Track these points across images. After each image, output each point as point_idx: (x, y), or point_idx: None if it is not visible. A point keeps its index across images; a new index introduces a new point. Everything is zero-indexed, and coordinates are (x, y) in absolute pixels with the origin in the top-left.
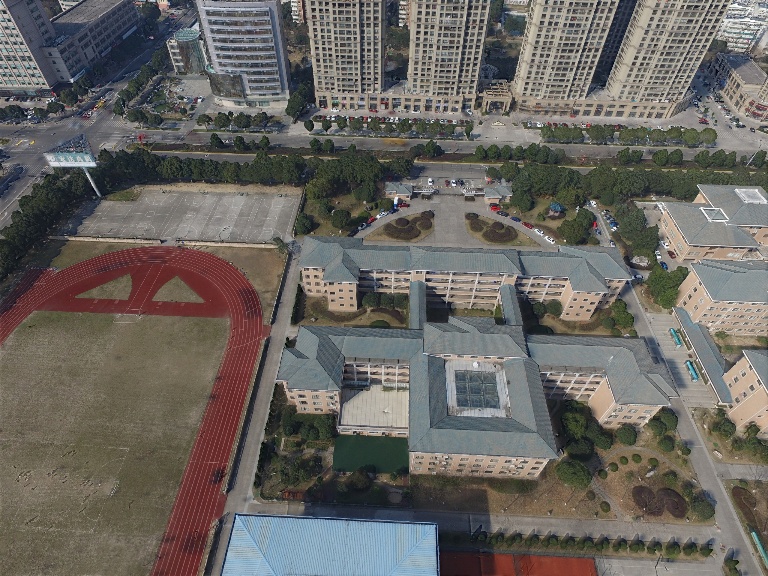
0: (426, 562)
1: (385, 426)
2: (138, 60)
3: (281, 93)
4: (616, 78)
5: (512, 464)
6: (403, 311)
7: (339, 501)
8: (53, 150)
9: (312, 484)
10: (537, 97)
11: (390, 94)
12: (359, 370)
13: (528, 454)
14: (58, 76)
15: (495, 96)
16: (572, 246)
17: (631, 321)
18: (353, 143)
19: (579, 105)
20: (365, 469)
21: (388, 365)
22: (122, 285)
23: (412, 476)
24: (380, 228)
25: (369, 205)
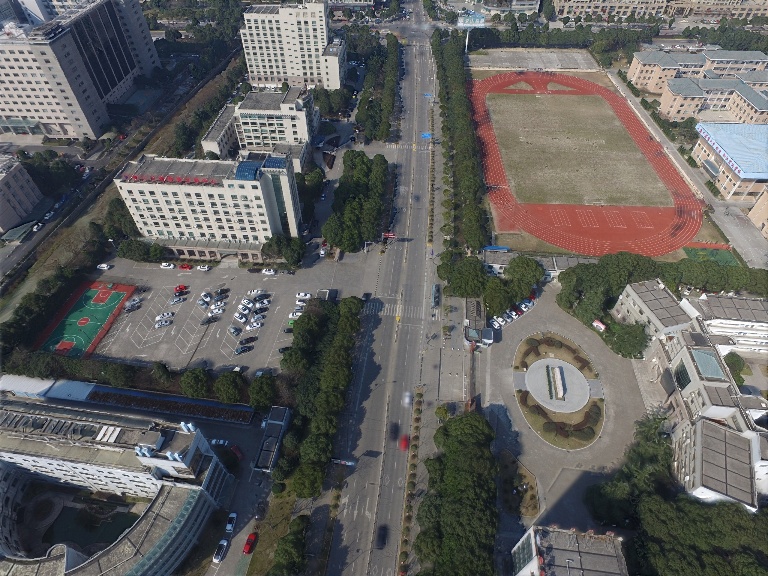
0: None
1: None
2: None
3: (535, 4)
4: None
5: None
6: None
7: None
8: (460, 16)
9: None
10: (708, 4)
11: (609, 3)
12: None
13: None
14: None
15: None
16: None
17: None
18: (596, 31)
19: (736, 9)
20: None
21: (724, 90)
22: (524, 85)
23: None
24: None
25: None
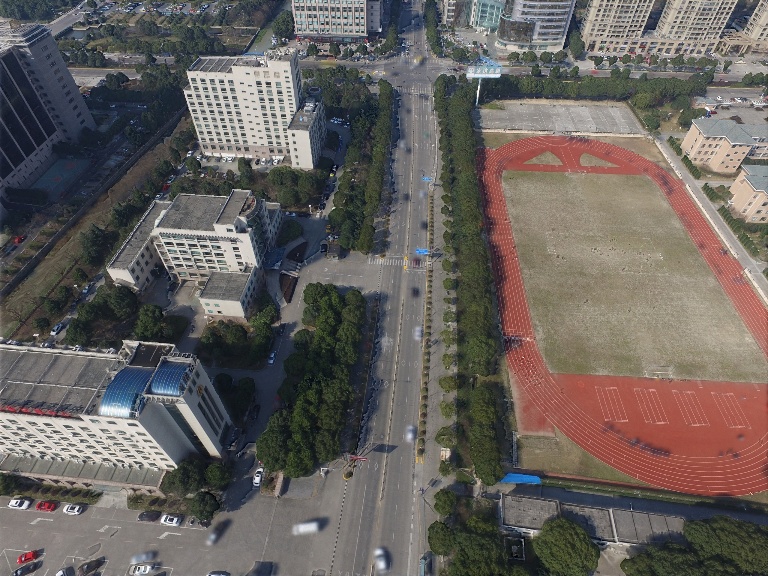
0: None
1: None
2: (402, 18)
3: (560, 38)
4: None
5: None
6: None
7: None
8: (470, 64)
9: None
10: None
11: (650, 39)
12: None
13: None
14: (369, 26)
15: None
16: None
17: None
18: (635, 75)
19: None
20: None
21: None
22: (551, 157)
23: None
24: None
25: None
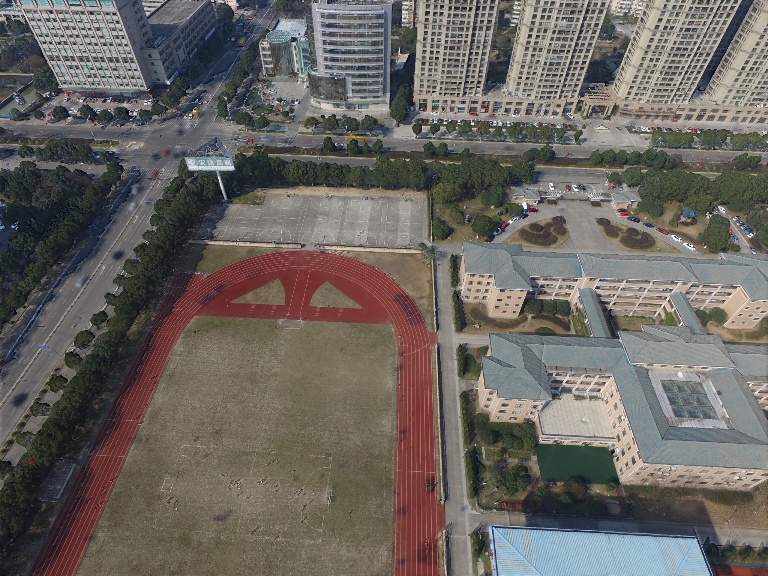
0: None
1: (588, 436)
2: (222, 61)
3: (382, 96)
4: (721, 82)
5: (736, 476)
6: (564, 318)
7: (559, 512)
8: (192, 154)
9: (526, 494)
10: (640, 101)
11: (492, 97)
12: (556, 379)
13: (765, 466)
14: (154, 78)
15: (597, 100)
16: (735, 254)
17: None
18: (462, 147)
19: (682, 109)
20: (575, 479)
21: (590, 374)
22: (275, 290)
23: (625, 487)
24: (515, 233)
25: (497, 210)
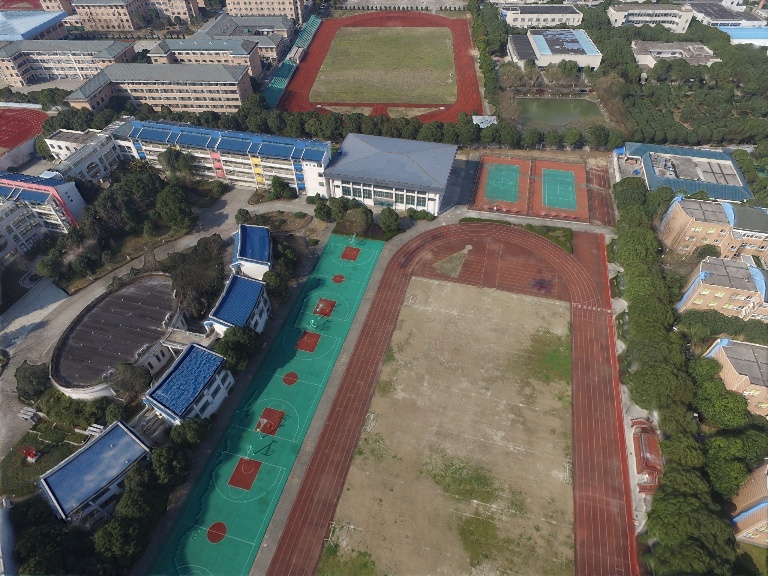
0: (55, 14)
1: None
2: None
3: None
4: None
5: (116, 16)
6: None
7: None
8: None
9: None
10: None
11: None
12: None
13: (114, 3)
14: None
15: None
16: None
17: (217, 1)
18: None
19: None
20: None
21: None
22: None
23: None
24: None
25: None
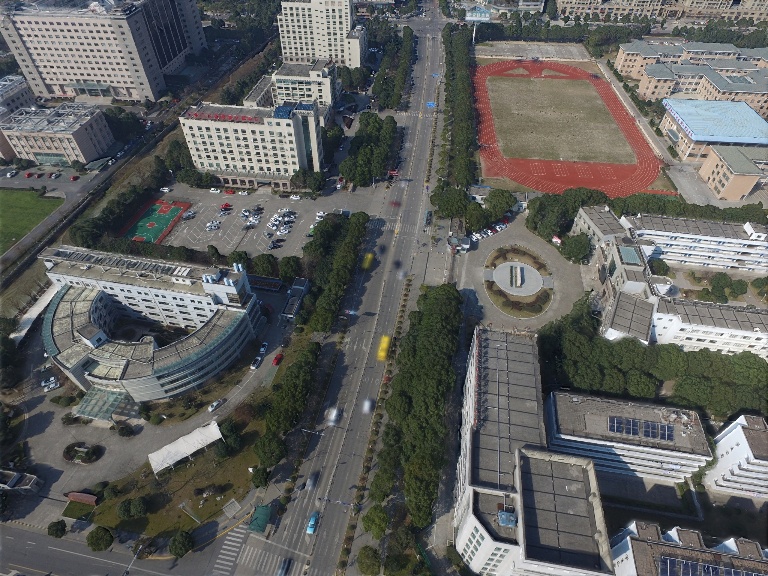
0: None
1: None
2: None
3: (539, 5)
4: None
5: (760, 103)
6: None
7: None
8: (468, 11)
9: None
10: (699, 8)
11: (608, 5)
12: (677, 81)
13: None
14: None
15: None
16: None
17: None
18: None
19: (725, 13)
20: None
21: (694, 75)
22: (522, 70)
23: None
24: None
25: None
